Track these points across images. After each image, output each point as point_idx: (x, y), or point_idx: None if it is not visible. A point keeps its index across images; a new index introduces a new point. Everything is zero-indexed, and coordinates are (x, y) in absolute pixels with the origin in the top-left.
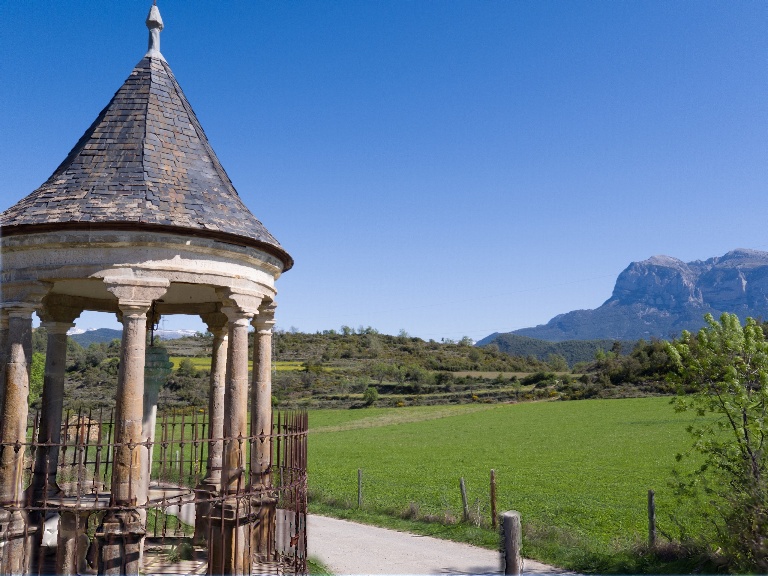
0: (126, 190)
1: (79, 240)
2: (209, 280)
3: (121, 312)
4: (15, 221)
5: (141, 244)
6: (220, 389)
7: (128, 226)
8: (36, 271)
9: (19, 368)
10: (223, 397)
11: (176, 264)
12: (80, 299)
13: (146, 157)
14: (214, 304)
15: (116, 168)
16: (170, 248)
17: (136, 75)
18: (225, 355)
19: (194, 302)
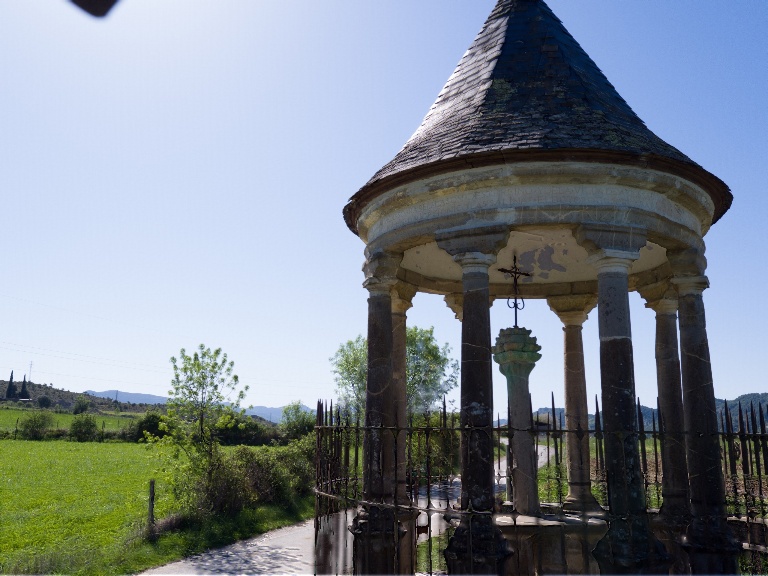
0: None
1: None
2: None
3: None
4: None
5: None
6: None
7: None
8: None
9: None
10: None
11: None
12: None
13: None
14: None
15: None
16: None
17: None
18: None
19: None
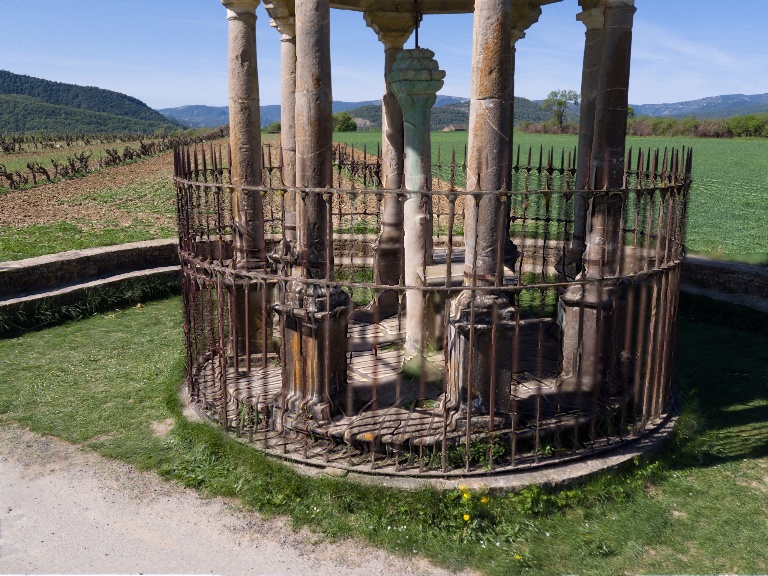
0: None
1: None
2: None
3: None
4: None
5: None
6: None
7: None
8: None
9: None
10: None
11: None
12: None
13: None
14: None
15: None
16: None
17: None
18: None
19: None
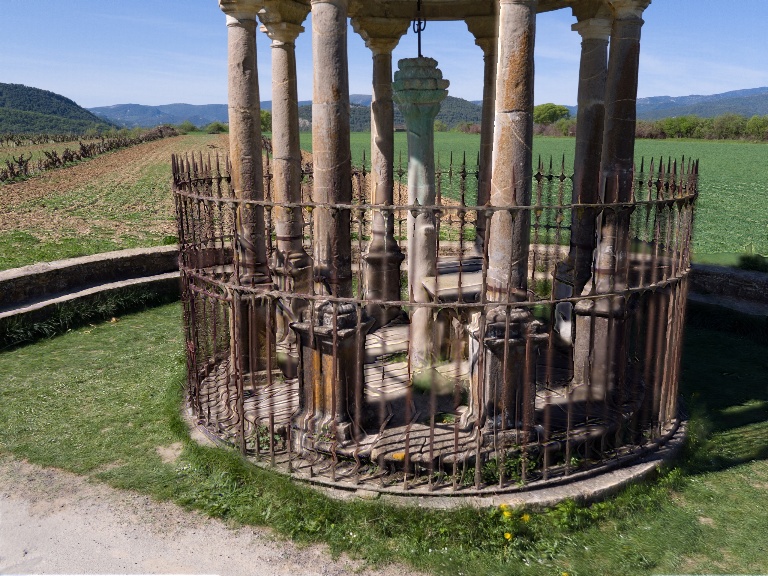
0: None
1: None
2: None
3: None
4: None
5: None
6: None
7: None
8: None
9: None
10: None
11: None
12: None
13: None
14: None
15: None
16: None
17: None
18: None
19: None
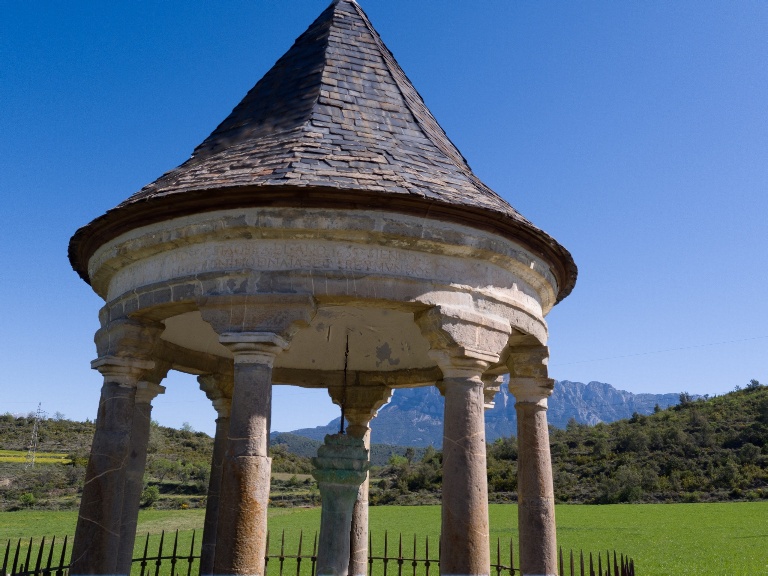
0: (437, 165)
1: (406, 231)
2: (536, 331)
3: (217, 374)
4: (291, 179)
5: (483, 255)
6: (363, 505)
7: (481, 220)
8: (311, 278)
9: (262, 467)
10: (366, 517)
11: (514, 297)
12: (171, 347)
13: (423, 126)
14: (354, 373)
15: (389, 132)
16: (508, 270)
17: (343, 18)
18: (368, 452)
19: (318, 368)
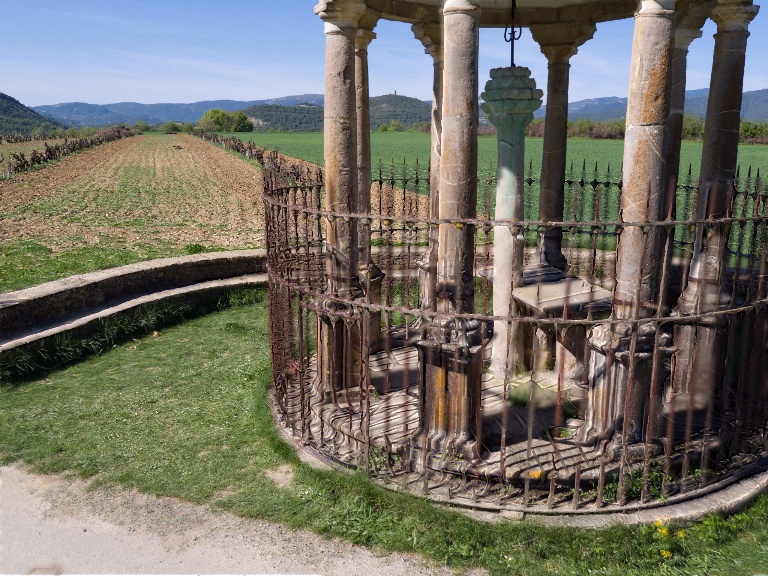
0: None
1: None
2: None
3: None
4: None
5: None
6: None
7: None
8: None
9: None
10: None
11: None
12: None
13: None
14: None
15: None
16: None
17: None
18: None
19: None
